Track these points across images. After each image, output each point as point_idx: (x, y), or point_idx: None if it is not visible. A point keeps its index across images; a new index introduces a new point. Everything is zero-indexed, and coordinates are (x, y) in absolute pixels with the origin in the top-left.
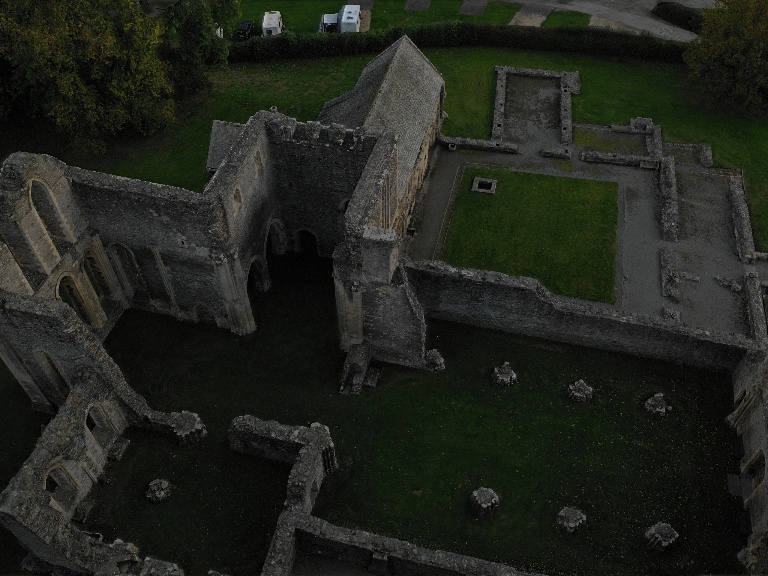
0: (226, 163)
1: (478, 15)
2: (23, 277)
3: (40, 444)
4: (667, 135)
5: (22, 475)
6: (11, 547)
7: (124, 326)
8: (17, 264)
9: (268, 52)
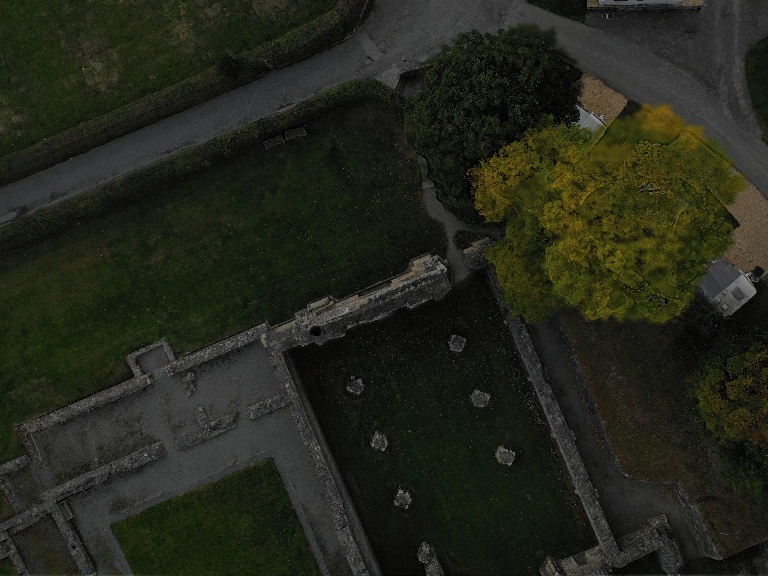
0: None
1: None
2: None
3: None
4: (1, 515)
5: None
6: None
7: None
8: None
9: None
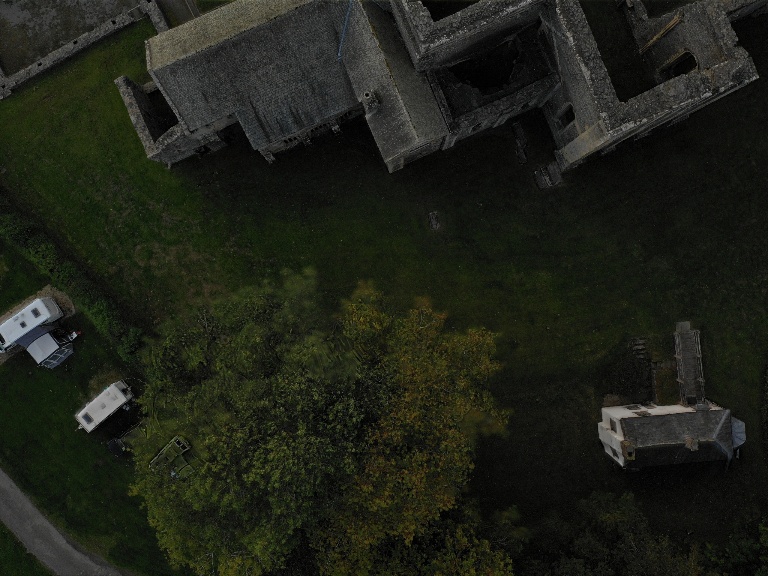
0: (507, 7)
1: None
2: None
3: (747, 0)
4: None
5: None
6: (766, 28)
7: None
8: None
9: None
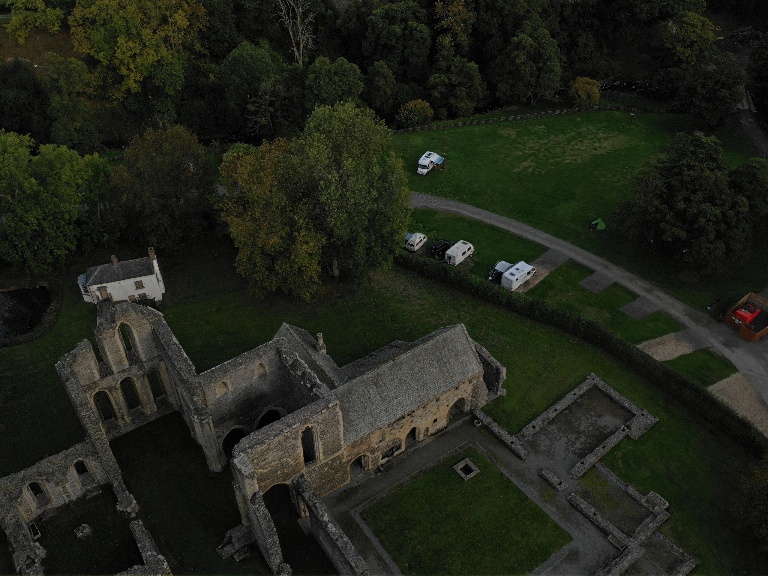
0: None
1: (634, 318)
2: (95, 369)
3: (38, 464)
4: (669, 527)
5: (17, 475)
6: None
7: (165, 420)
8: (93, 361)
9: (432, 273)
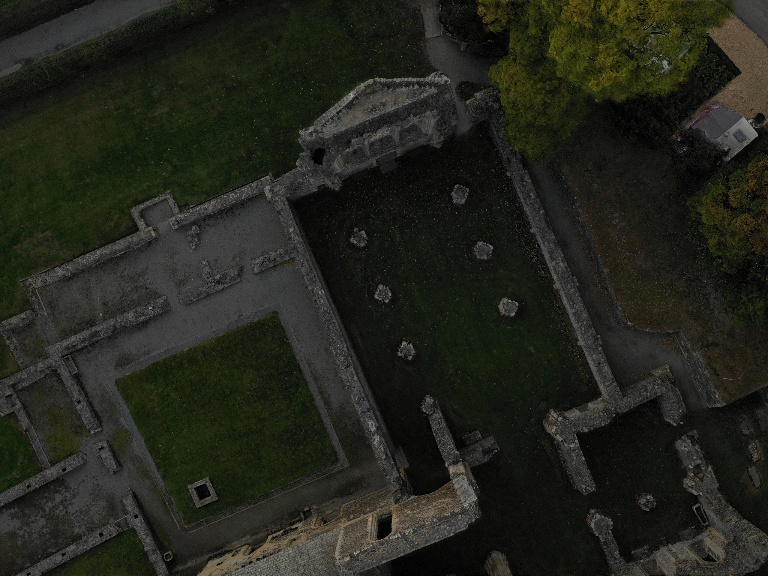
0: None
1: None
2: None
3: None
4: (7, 370)
5: (736, 572)
6: None
7: None
8: None
9: None
